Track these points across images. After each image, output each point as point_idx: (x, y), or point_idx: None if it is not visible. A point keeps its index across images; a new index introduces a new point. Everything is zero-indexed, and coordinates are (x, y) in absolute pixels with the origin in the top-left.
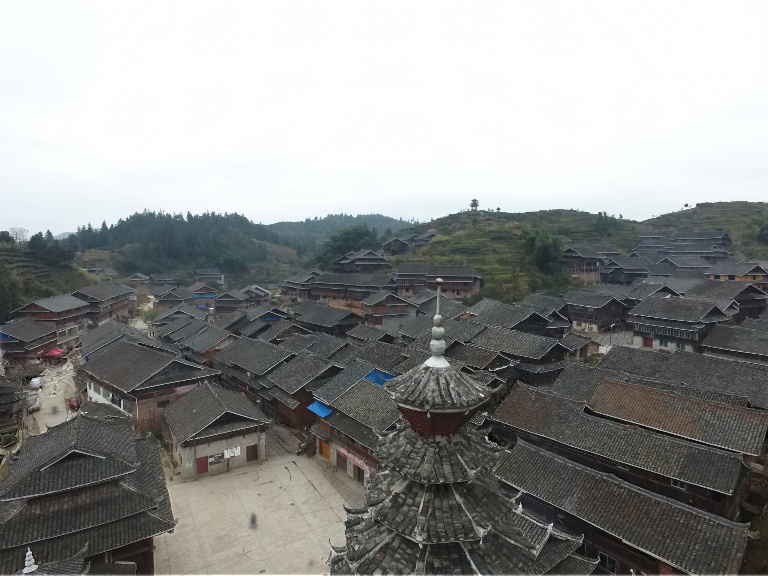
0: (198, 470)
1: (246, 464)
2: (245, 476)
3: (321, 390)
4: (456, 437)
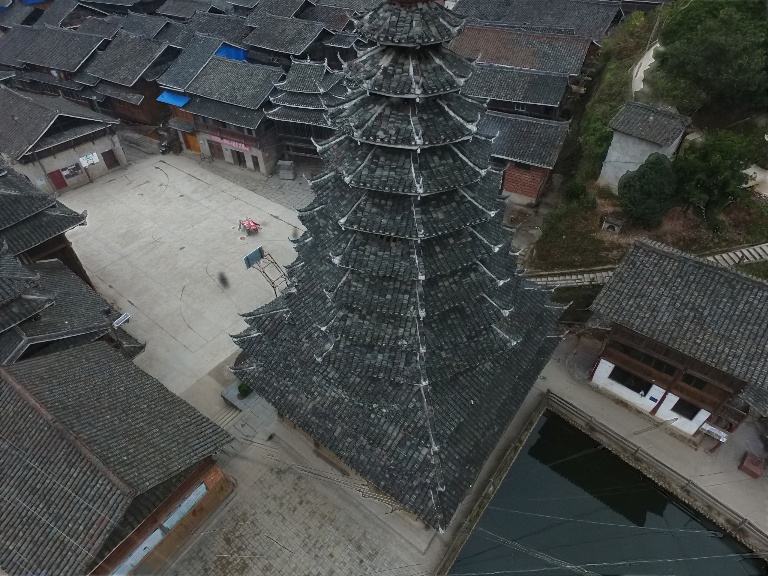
0: (55, 186)
1: (108, 172)
2: (114, 182)
3: (166, 76)
4: (434, 4)
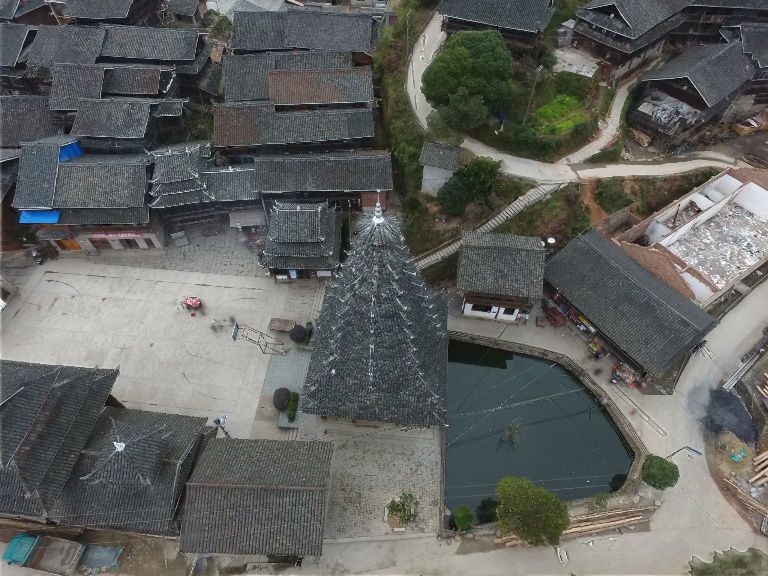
0: None
1: None
2: (23, 313)
3: (20, 199)
4: None
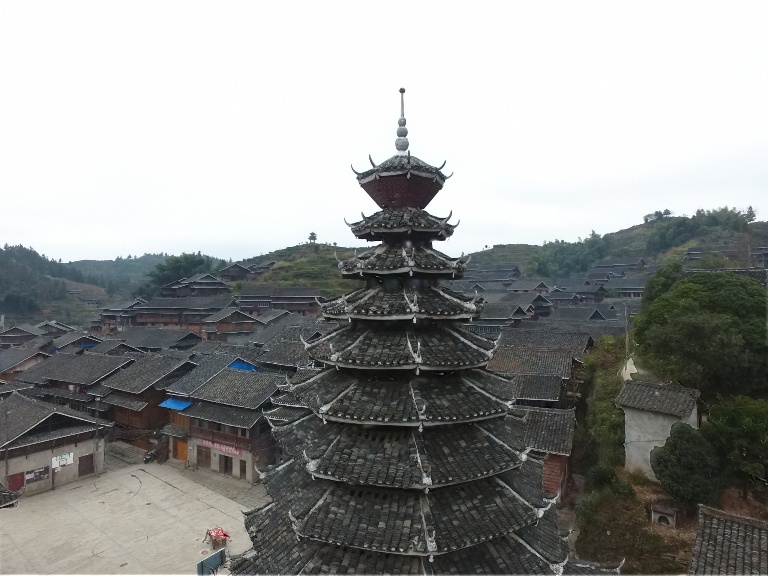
0: None
1: (78, 479)
2: (79, 490)
3: (176, 385)
4: None
